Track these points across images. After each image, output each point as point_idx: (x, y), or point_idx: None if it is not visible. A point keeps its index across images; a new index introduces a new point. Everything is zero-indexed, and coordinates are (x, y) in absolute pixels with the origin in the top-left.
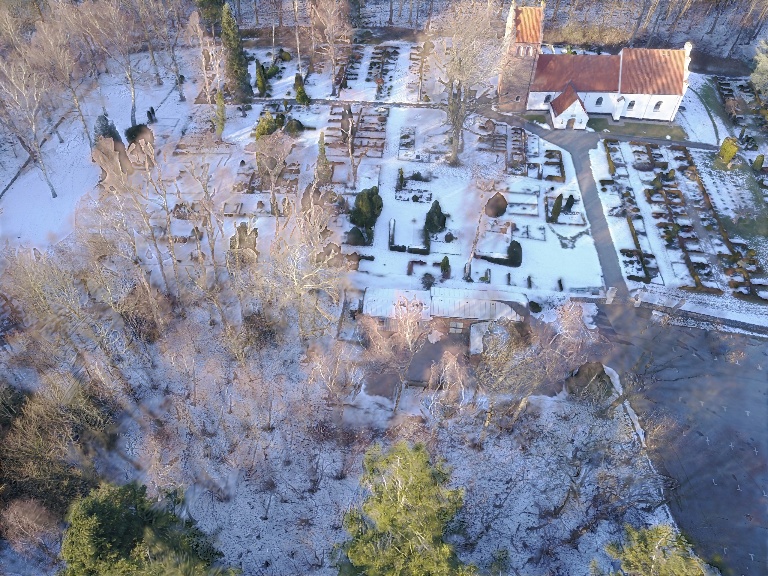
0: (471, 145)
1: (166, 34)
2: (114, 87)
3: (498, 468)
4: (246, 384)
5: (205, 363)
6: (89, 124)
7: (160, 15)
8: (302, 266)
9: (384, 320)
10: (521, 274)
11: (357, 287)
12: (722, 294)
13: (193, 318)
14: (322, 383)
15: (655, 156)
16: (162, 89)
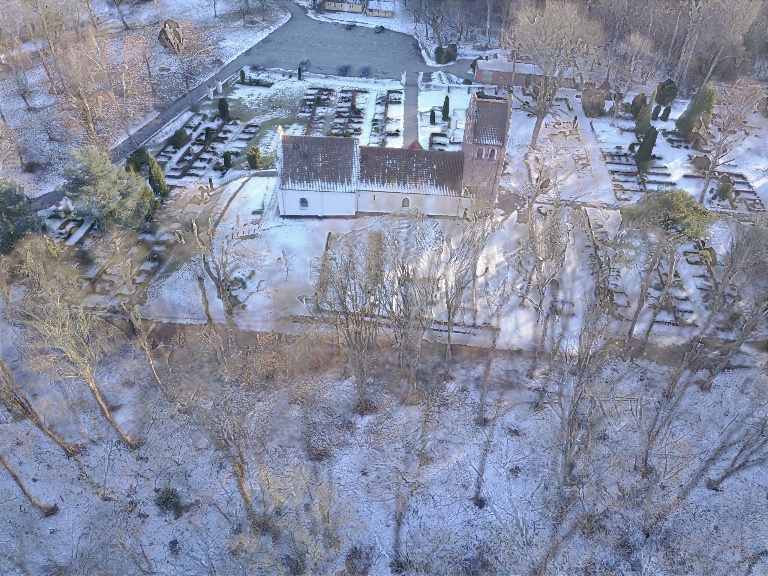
0: (517, 161)
1: None
2: None
3: None
4: None
5: None
6: None
7: None
8: None
9: None
10: None
11: None
12: None
13: None
14: None
15: None
16: None
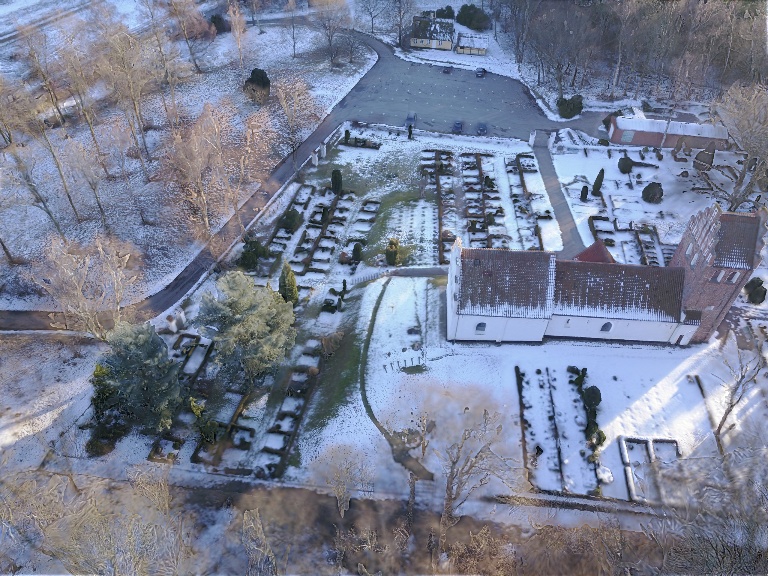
0: None
1: None
2: None
3: None
4: None
5: None
6: None
7: None
8: None
9: None
10: (616, 160)
11: None
12: None
13: None
14: None
15: None
16: None
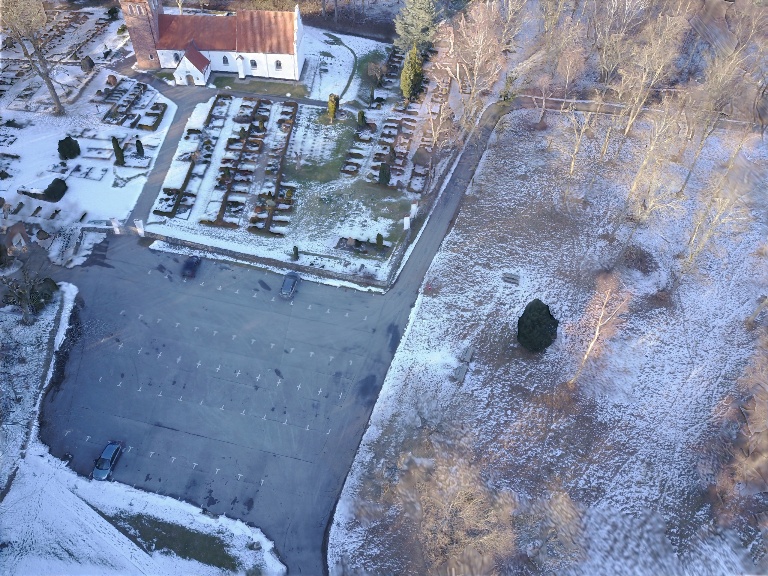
0: (87, 98)
1: None
2: None
3: None
4: None
5: None
6: None
7: None
8: None
9: None
10: (54, 208)
11: None
12: (237, 228)
13: None
14: None
15: (261, 110)
16: None
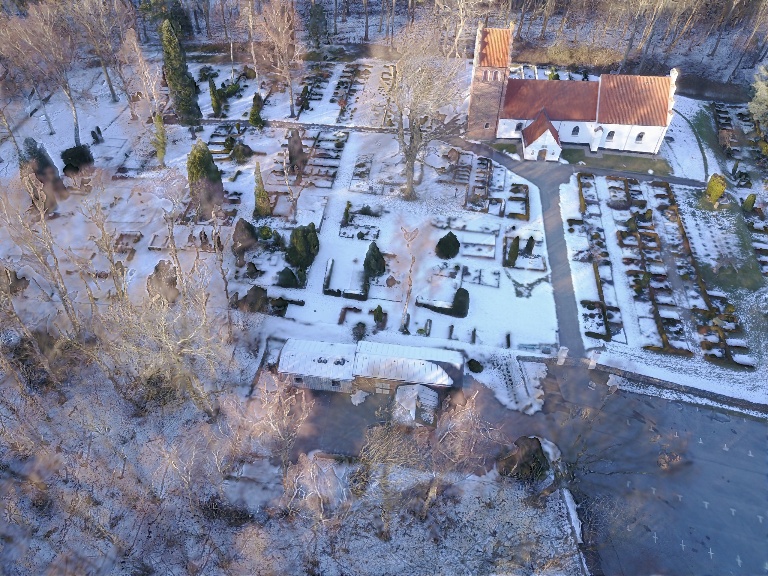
0: (431, 176)
1: (111, 50)
2: (69, 103)
3: (406, 562)
4: (143, 445)
5: (105, 417)
6: (21, 145)
7: (103, 31)
8: (181, 328)
9: (302, 377)
10: (466, 326)
11: (281, 336)
12: (692, 356)
13: (100, 365)
14: (176, 474)
15: (633, 193)
16: (117, 106)
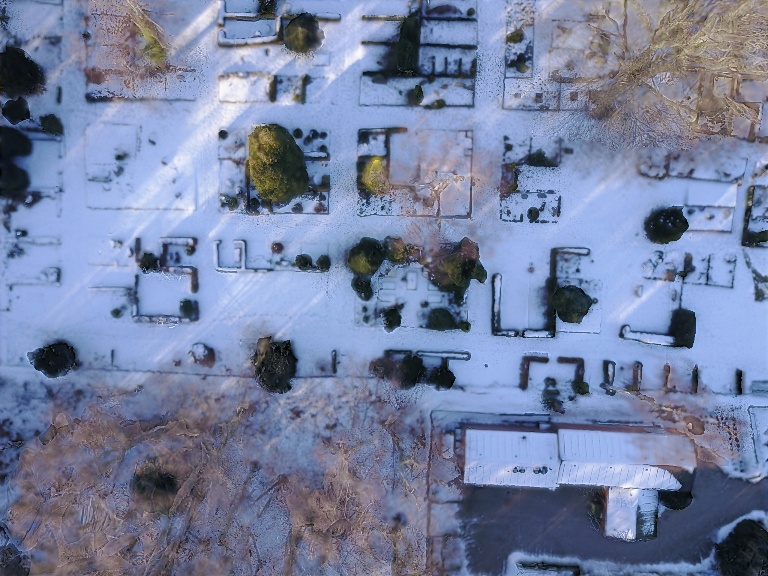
0: None
1: None
2: None
3: None
4: None
5: None
6: None
7: None
8: None
9: None
10: (685, 361)
11: (448, 408)
12: None
13: (226, 455)
14: None
15: None
16: None
